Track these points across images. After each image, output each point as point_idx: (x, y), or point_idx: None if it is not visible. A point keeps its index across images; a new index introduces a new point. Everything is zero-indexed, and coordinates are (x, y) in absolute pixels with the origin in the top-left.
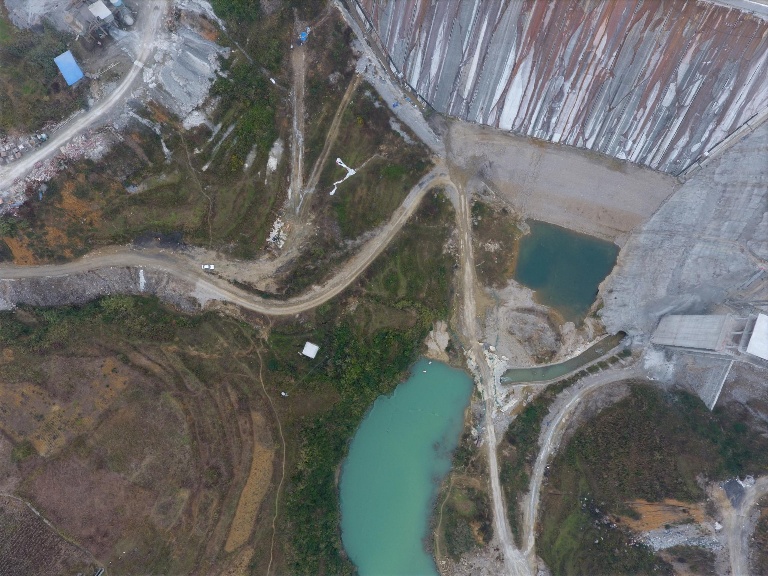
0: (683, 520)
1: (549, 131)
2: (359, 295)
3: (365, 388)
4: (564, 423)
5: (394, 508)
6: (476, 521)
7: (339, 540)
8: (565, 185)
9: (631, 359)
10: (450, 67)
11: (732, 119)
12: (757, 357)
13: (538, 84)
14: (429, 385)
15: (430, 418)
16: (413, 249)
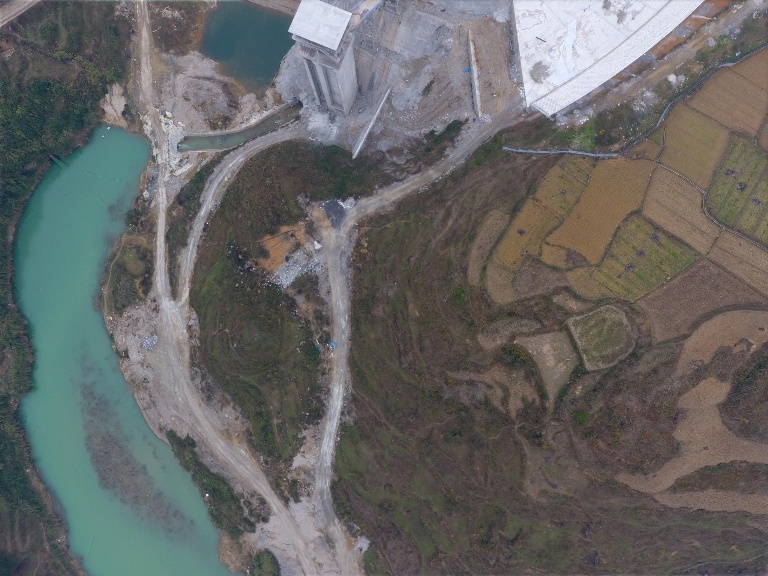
0: (294, 246)
1: None
2: (13, 41)
3: (17, 132)
4: (226, 181)
5: (70, 268)
6: (140, 277)
7: (7, 291)
8: None
9: (297, 122)
10: None
11: None
12: (306, 42)
13: None
14: (110, 152)
15: (111, 185)
16: (78, 5)
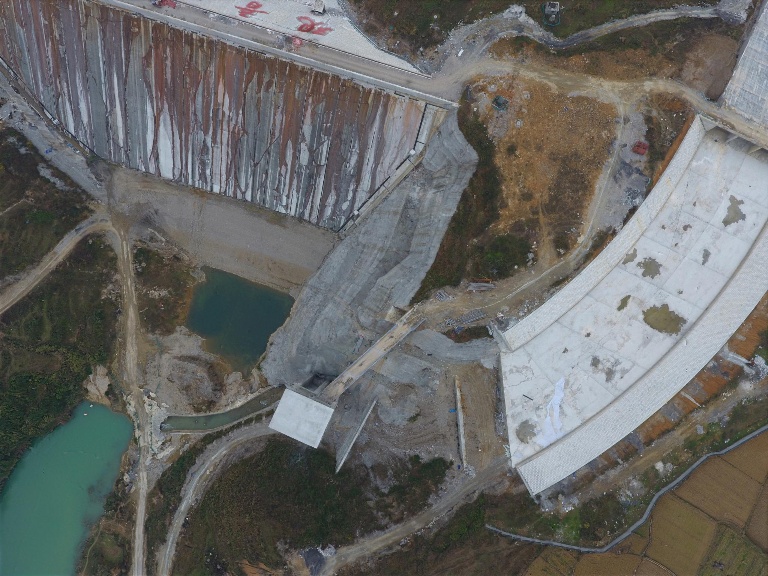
0: None
1: (208, 182)
2: None
3: None
4: (208, 475)
5: (46, 549)
6: (118, 568)
7: None
8: (231, 235)
9: None
10: (98, 116)
11: (369, 180)
12: None
13: (182, 137)
14: (92, 428)
15: (92, 460)
16: (64, 294)
